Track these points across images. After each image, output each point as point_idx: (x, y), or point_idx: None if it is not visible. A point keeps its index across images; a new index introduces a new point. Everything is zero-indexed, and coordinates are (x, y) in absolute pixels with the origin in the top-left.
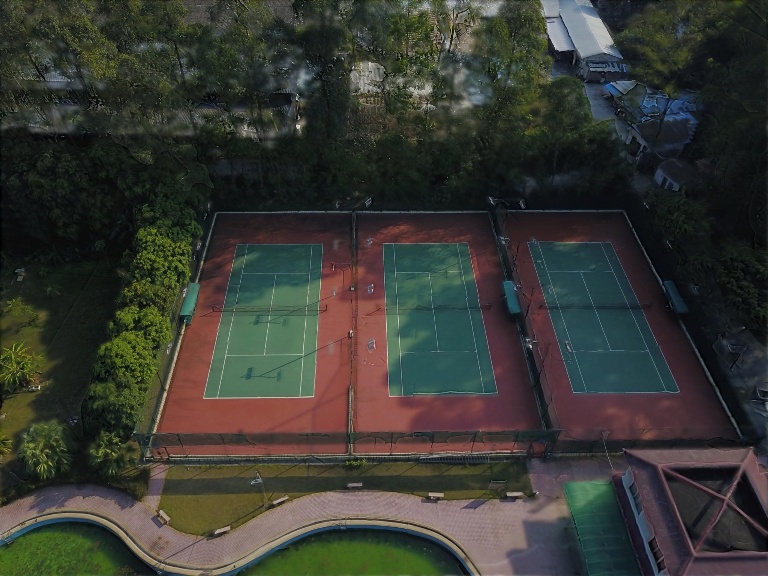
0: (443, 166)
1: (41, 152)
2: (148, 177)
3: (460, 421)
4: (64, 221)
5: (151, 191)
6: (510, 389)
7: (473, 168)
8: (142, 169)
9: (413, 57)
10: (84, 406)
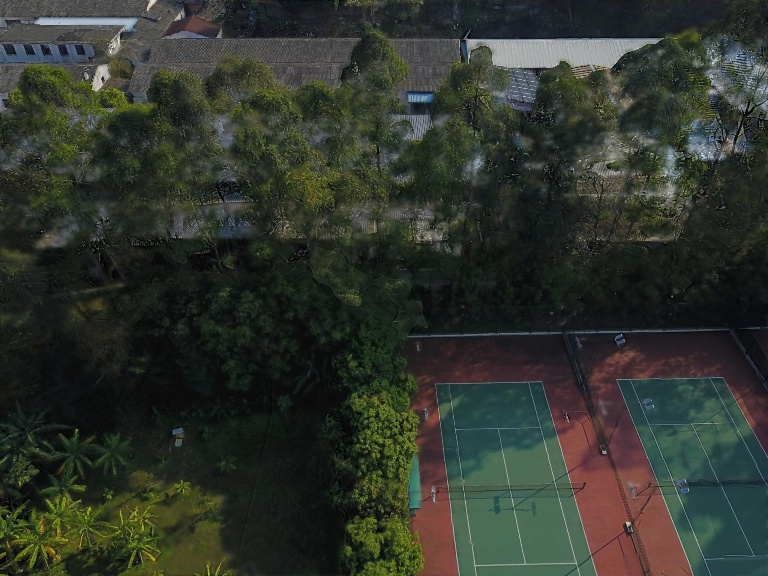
0: None
1: (214, 290)
2: (346, 317)
3: None
4: (237, 372)
5: (351, 335)
6: None
7: (719, 280)
8: (335, 304)
9: (682, 158)
10: None
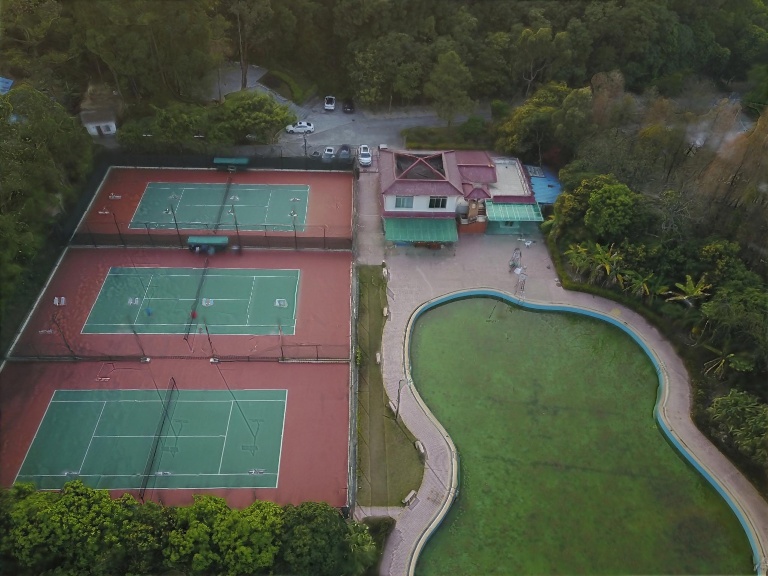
0: (13, 243)
1: None
2: None
3: (327, 290)
4: None
5: None
6: (296, 263)
7: None
8: None
9: None
10: (309, 572)
